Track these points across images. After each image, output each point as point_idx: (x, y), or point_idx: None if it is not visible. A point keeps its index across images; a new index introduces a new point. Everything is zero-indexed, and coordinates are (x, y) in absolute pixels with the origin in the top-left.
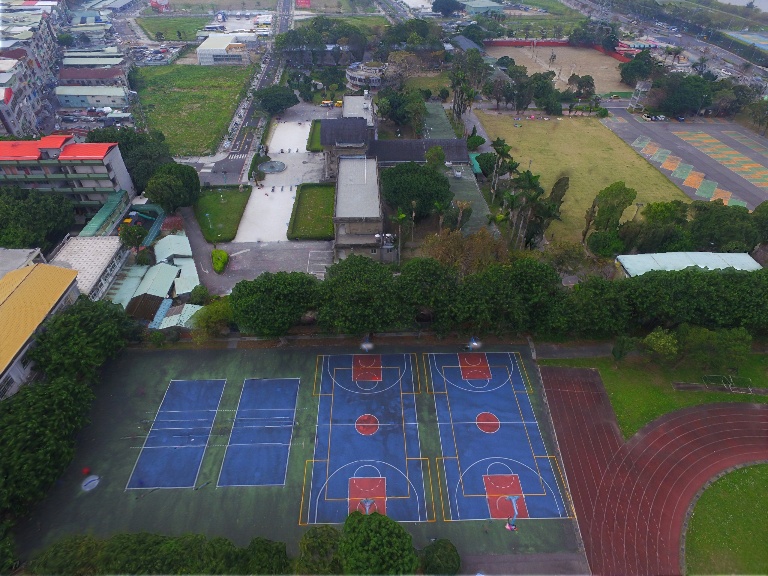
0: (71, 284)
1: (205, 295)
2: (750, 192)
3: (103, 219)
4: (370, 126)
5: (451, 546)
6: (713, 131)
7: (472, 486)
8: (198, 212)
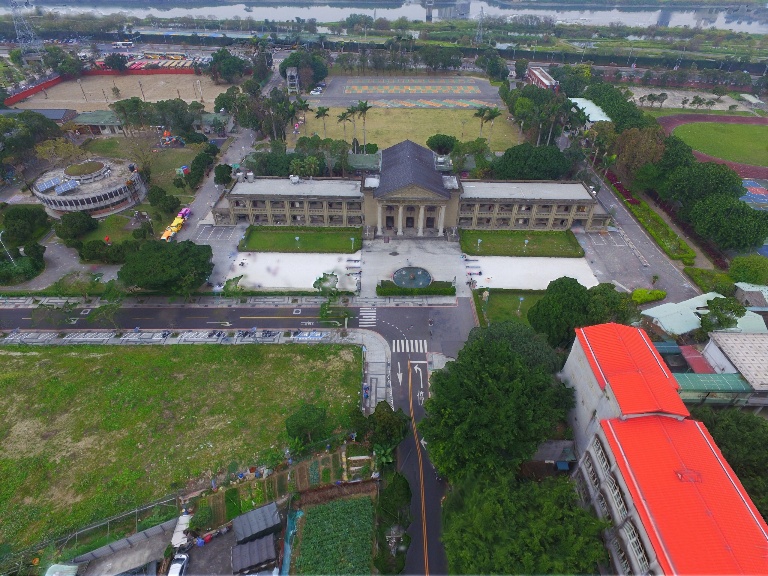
0: None
1: None
2: (446, 96)
3: (688, 374)
4: None
5: None
6: (347, 84)
7: (762, 197)
8: None
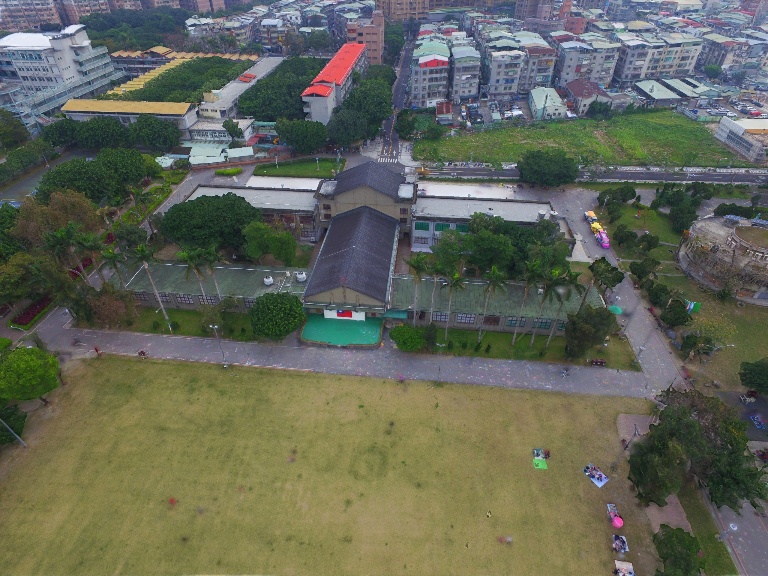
0: (177, 115)
1: (177, 163)
2: None
3: None
4: (414, 213)
5: None
6: None
7: None
8: (303, 161)
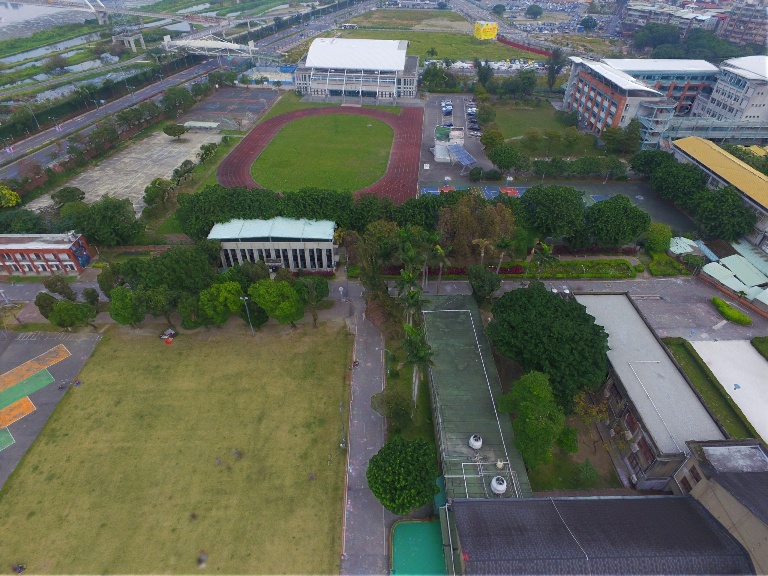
0: None
1: (687, 256)
2: None
3: None
4: None
5: (474, 172)
6: None
7: None
8: None
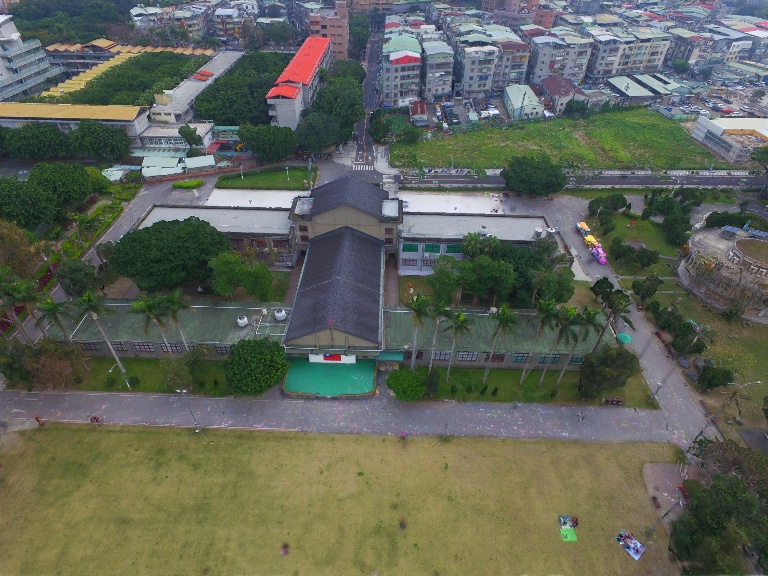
0: (125, 121)
1: (127, 176)
2: None
3: (236, 129)
4: (401, 234)
5: None
6: None
7: None
8: (271, 170)
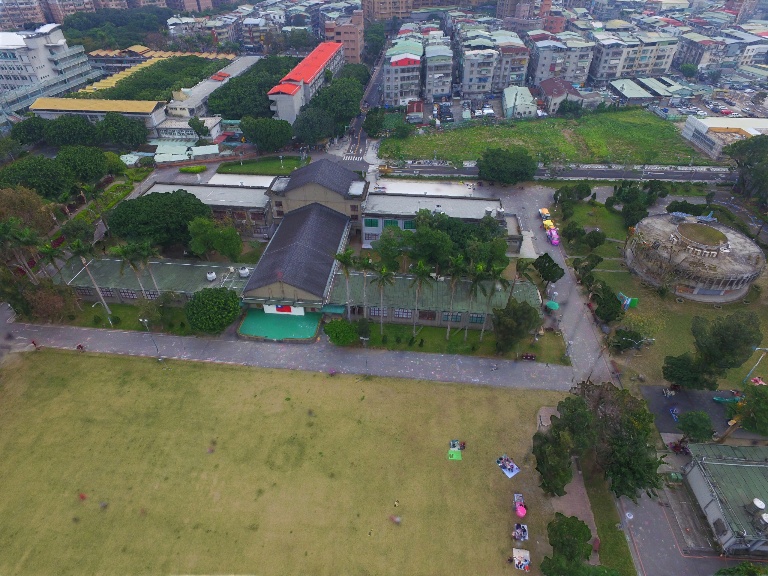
0: (143, 113)
1: (141, 161)
2: None
3: None
4: (363, 210)
5: None
6: None
7: None
8: (268, 159)
